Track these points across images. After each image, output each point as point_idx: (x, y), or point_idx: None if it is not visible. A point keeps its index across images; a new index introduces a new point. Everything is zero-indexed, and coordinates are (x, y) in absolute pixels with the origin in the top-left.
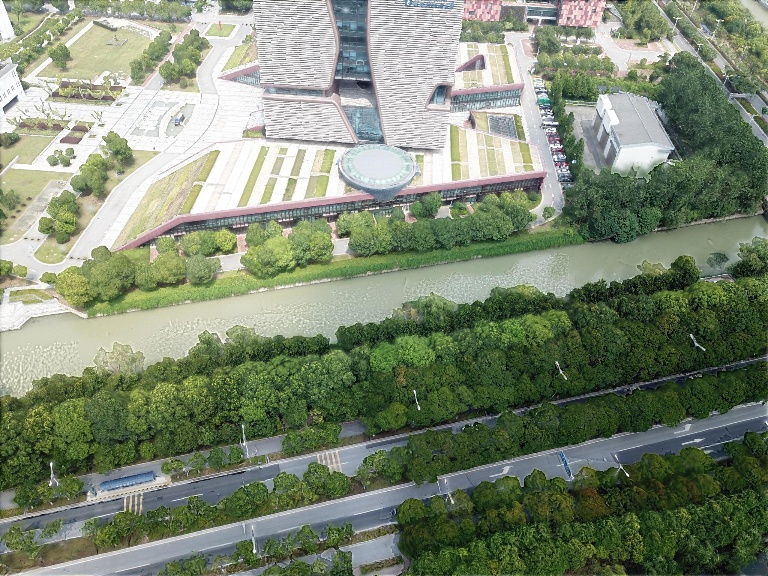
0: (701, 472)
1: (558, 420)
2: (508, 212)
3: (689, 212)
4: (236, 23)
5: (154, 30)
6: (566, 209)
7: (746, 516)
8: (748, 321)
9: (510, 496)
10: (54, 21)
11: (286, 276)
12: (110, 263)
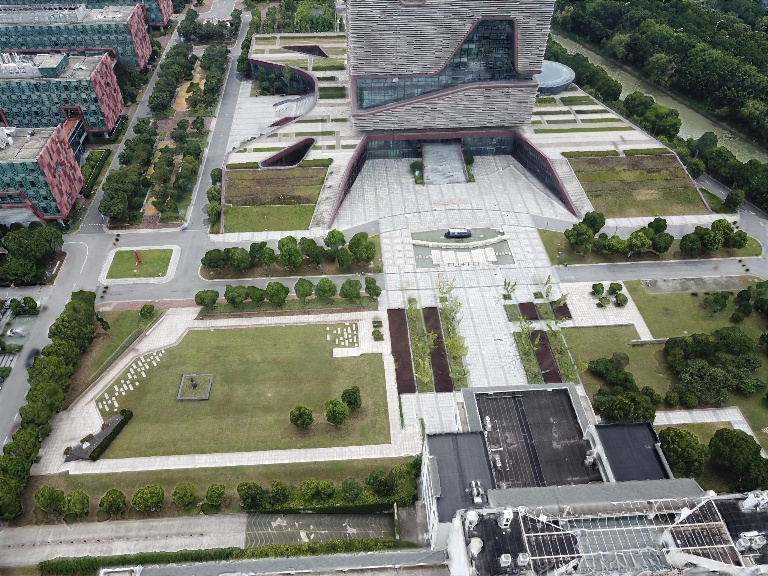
0: None
1: None
2: None
3: None
4: (105, 254)
5: (128, 353)
6: None
7: None
8: None
9: None
10: (67, 559)
11: None
12: (762, 165)
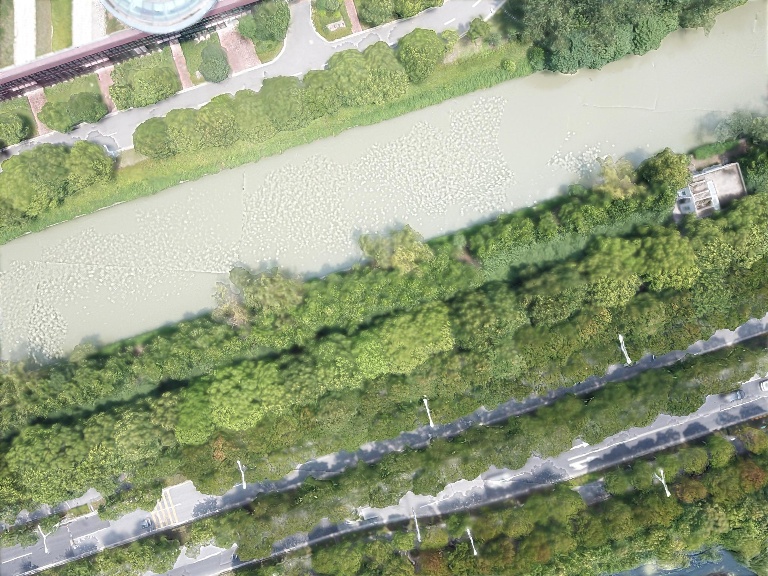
0: (564, 524)
1: (412, 482)
2: (400, 59)
3: (732, 2)
4: None
5: None
6: (515, 3)
7: (593, 571)
8: (711, 308)
9: (346, 573)
10: None
11: (55, 210)
12: None
